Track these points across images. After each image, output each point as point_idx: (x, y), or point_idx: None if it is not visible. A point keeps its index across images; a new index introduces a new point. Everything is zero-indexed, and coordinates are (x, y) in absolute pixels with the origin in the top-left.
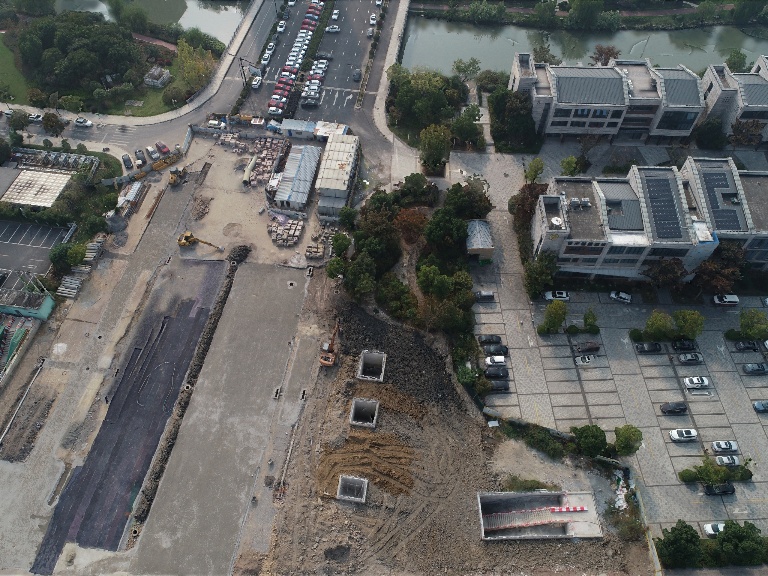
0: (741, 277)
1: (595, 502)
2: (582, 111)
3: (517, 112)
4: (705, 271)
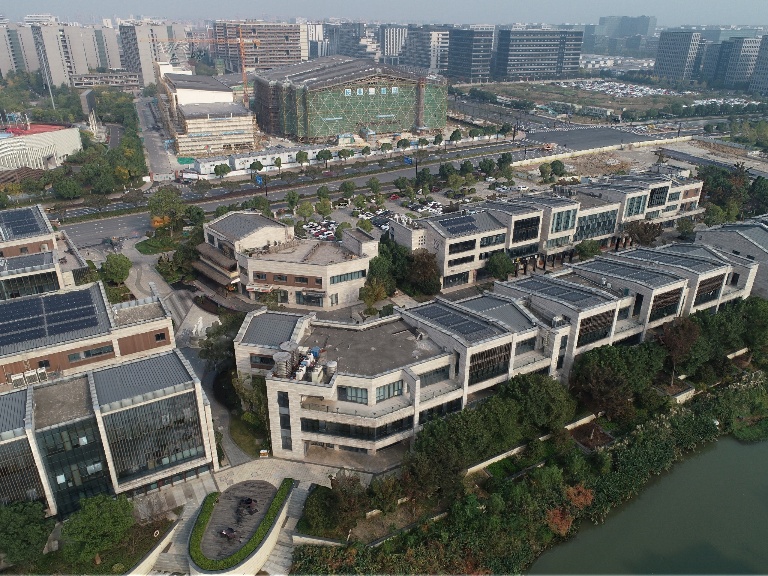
0: None
1: (537, 176)
2: None
3: None
4: None
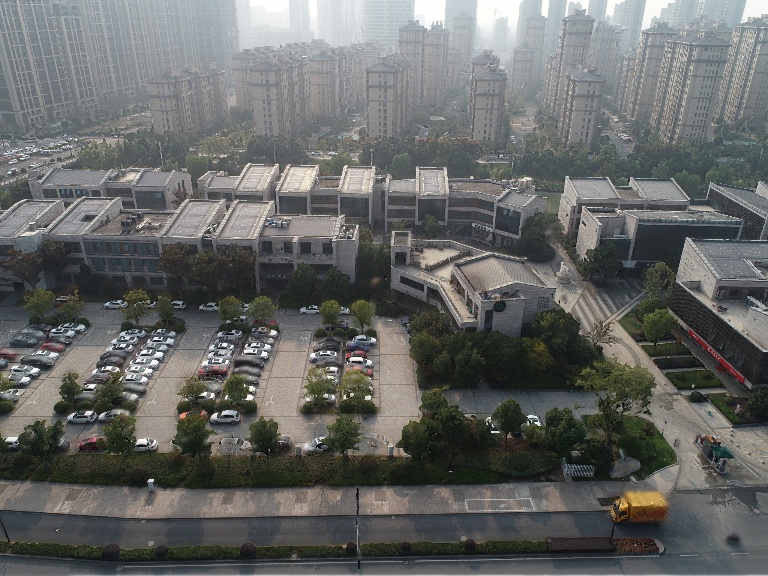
0: (39, 261)
1: None
2: (65, 191)
3: (11, 192)
4: (12, 258)
